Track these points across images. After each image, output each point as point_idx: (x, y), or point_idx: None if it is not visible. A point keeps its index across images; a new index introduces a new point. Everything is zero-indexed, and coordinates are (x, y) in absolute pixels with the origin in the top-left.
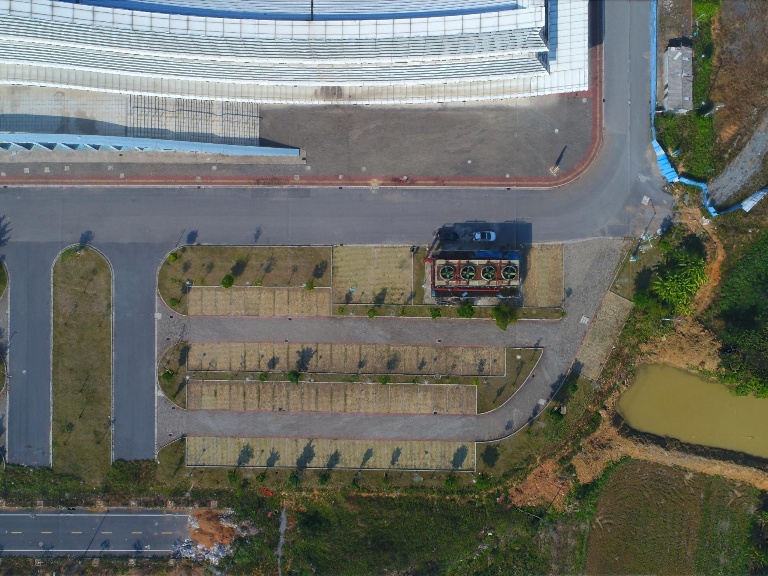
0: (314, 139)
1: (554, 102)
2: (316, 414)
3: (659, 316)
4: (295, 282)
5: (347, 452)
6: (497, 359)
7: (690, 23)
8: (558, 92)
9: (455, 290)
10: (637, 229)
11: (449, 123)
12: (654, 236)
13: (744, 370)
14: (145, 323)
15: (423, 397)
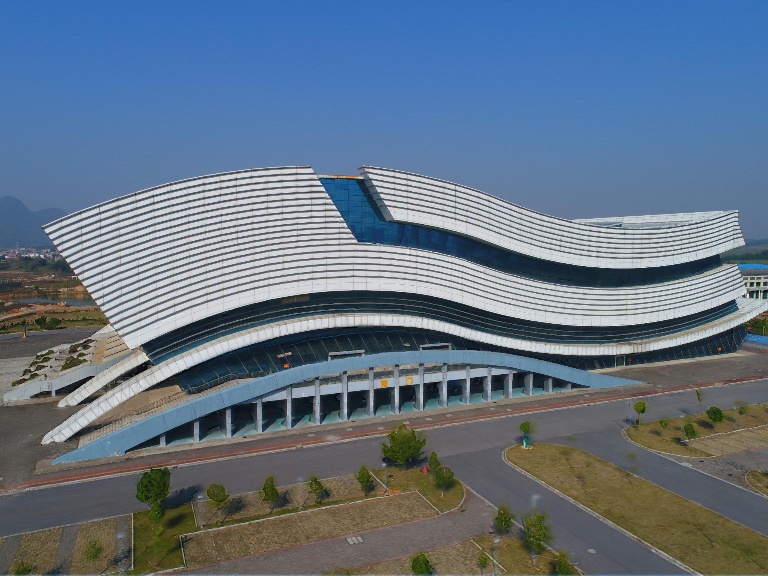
0: None
1: None
2: None
3: None
4: None
5: None
6: None
7: None
8: (759, 313)
9: None
10: None
11: (715, 363)
12: None
13: None
14: (681, 471)
15: None
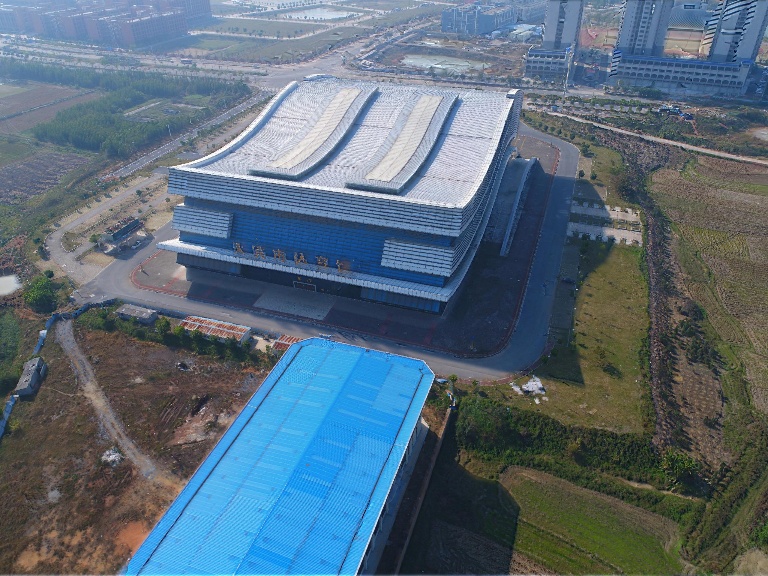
0: None
1: None
2: (120, 200)
3: None
4: None
5: None
6: None
7: None
8: None
9: None
10: None
11: None
12: None
13: None
14: None
15: None
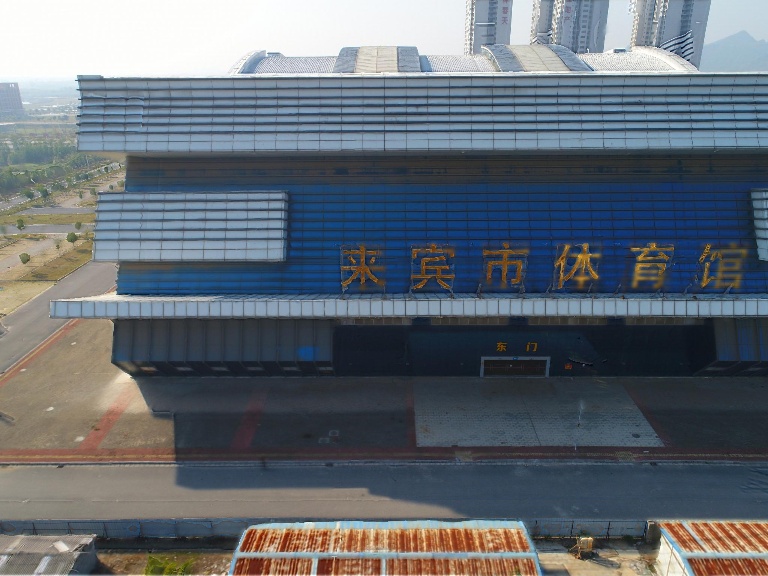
0: None
1: (102, 406)
2: None
3: None
4: None
5: None
6: None
7: None
8: None
9: None
10: None
11: None
12: None
13: None
14: None
15: None
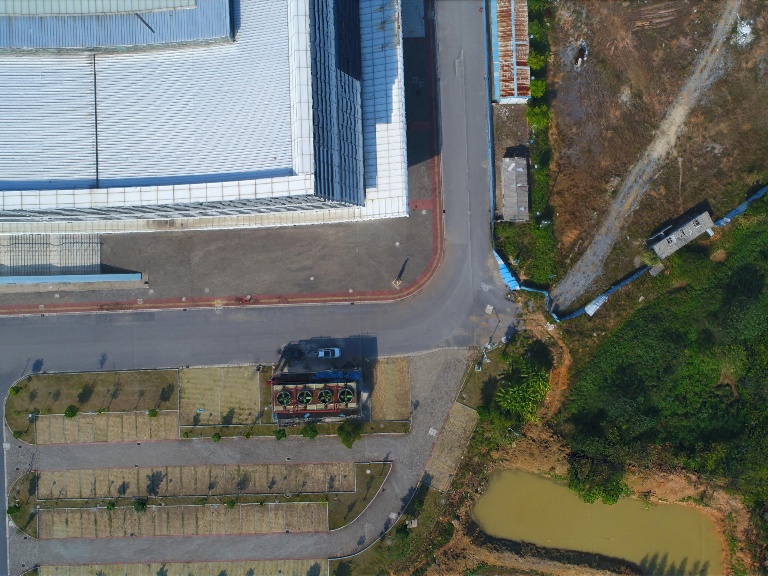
0: (156, 263)
1: None
2: (168, 538)
3: (505, 426)
4: (142, 406)
5: (200, 575)
6: (347, 475)
7: (526, 131)
8: (382, 217)
9: (297, 412)
10: (482, 338)
11: (290, 241)
12: (499, 344)
13: (591, 476)
14: None
15: (274, 516)
